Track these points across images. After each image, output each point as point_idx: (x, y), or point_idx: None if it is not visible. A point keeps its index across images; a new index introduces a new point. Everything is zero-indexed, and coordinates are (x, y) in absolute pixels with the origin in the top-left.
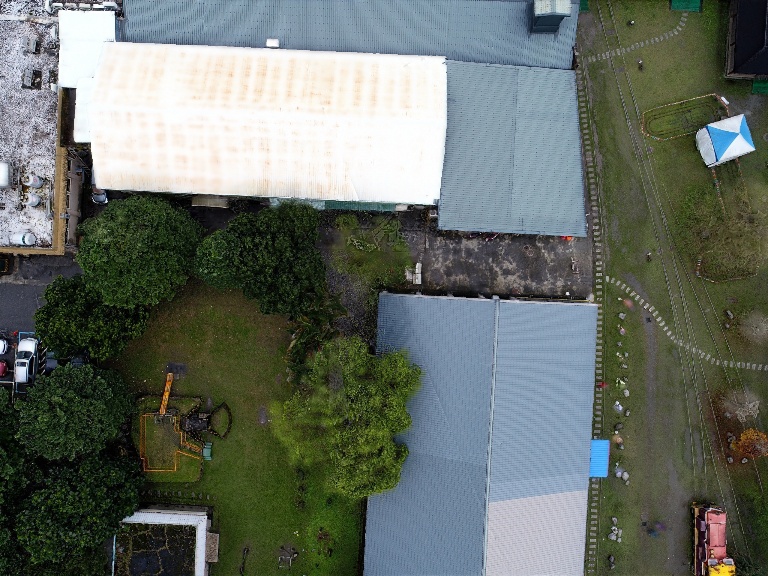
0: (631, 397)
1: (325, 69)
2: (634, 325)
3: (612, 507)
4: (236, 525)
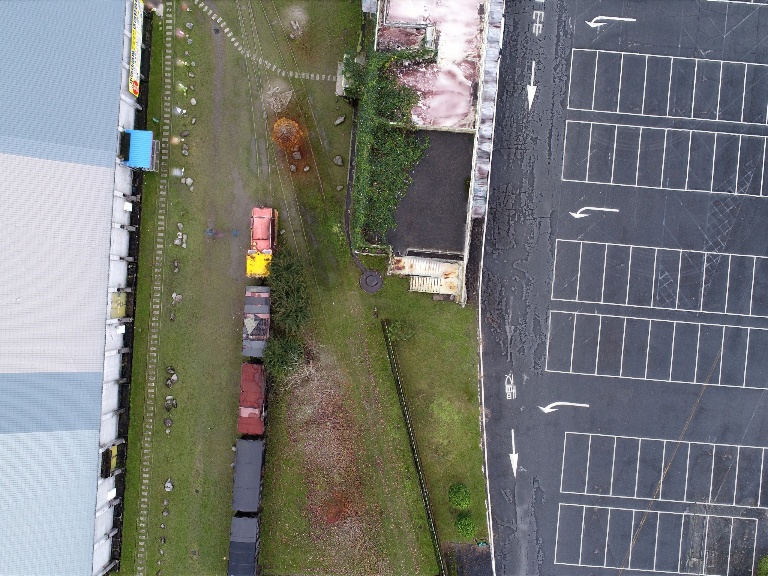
0: (198, 106)
1: None
2: (202, 36)
3: (179, 214)
4: None
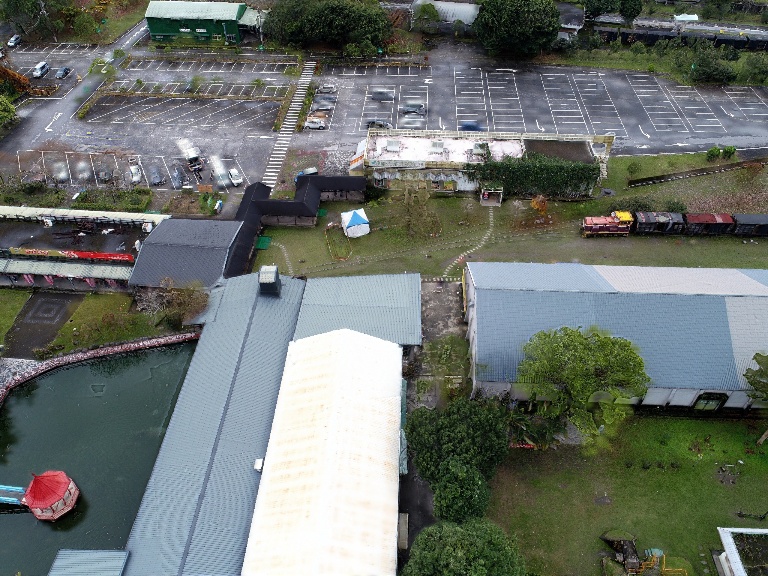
0: None
1: (290, 417)
2: None
3: None
4: (719, 526)
